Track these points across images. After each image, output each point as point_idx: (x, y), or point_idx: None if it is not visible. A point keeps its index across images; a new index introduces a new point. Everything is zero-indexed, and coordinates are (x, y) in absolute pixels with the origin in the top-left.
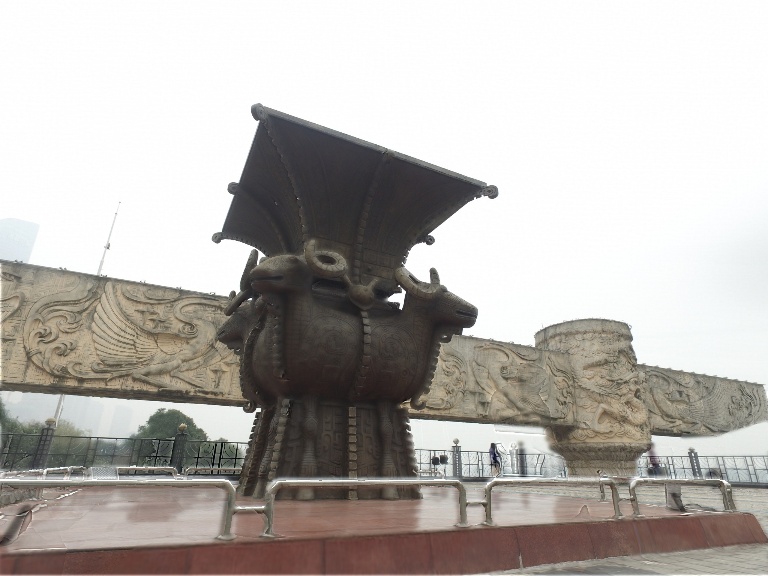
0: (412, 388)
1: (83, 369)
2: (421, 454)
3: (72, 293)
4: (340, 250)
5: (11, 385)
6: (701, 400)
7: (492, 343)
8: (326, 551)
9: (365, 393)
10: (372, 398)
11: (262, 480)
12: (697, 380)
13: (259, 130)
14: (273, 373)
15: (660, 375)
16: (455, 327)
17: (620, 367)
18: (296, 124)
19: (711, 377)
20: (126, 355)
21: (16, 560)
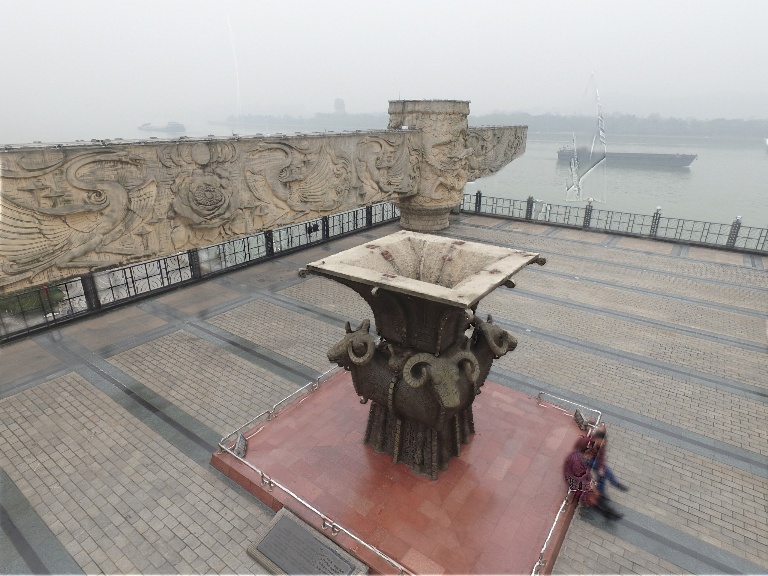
0: None
1: None
2: (299, 228)
3: None
4: None
5: None
6: (493, 149)
7: (371, 136)
8: None
9: None
10: None
11: (420, 465)
12: (495, 133)
13: None
14: None
15: (475, 135)
16: None
17: (458, 145)
18: None
19: (503, 128)
20: (37, 246)
21: None
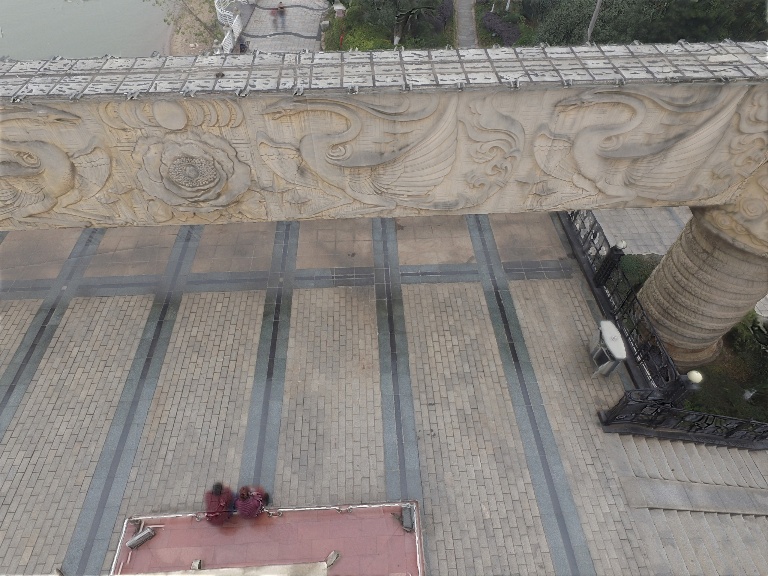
0: None
1: None
2: None
3: None
4: None
5: None
6: None
7: None
8: None
9: None
10: None
11: None
12: None
13: None
14: None
15: None
16: None
17: None
18: None
19: None
20: None
21: None
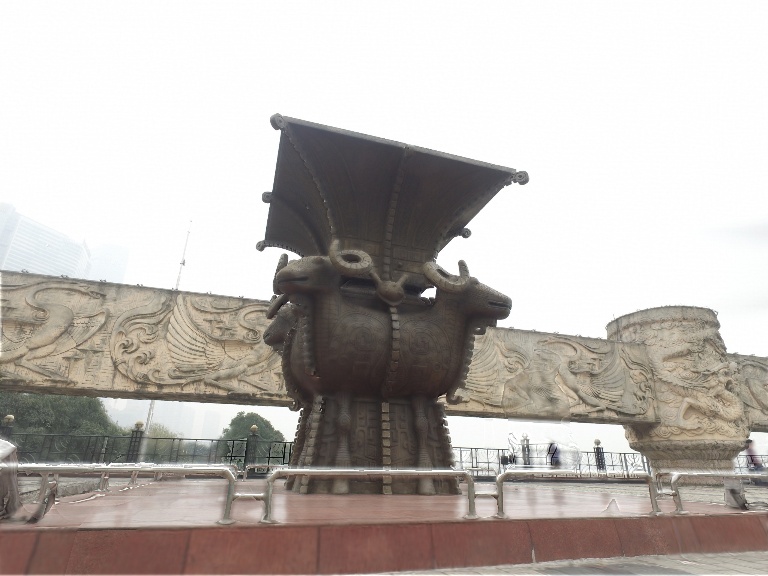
0: (446, 382)
1: (161, 376)
2: (488, 453)
3: (149, 307)
4: (369, 248)
5: (102, 392)
6: None
7: (557, 337)
8: (321, 538)
9: (398, 388)
10: (406, 393)
11: None
12: None
13: (282, 138)
14: (305, 371)
15: (757, 365)
16: (489, 319)
17: (706, 357)
18: (316, 128)
19: None
20: (198, 362)
21: (34, 536)
